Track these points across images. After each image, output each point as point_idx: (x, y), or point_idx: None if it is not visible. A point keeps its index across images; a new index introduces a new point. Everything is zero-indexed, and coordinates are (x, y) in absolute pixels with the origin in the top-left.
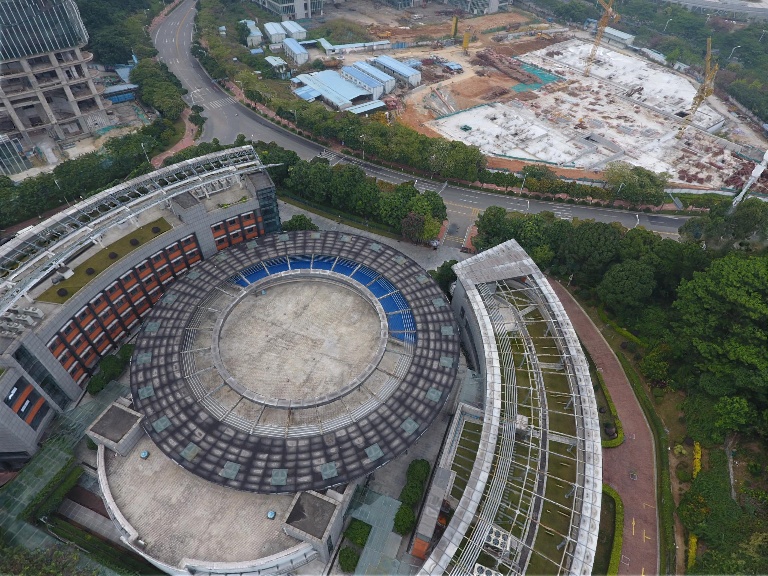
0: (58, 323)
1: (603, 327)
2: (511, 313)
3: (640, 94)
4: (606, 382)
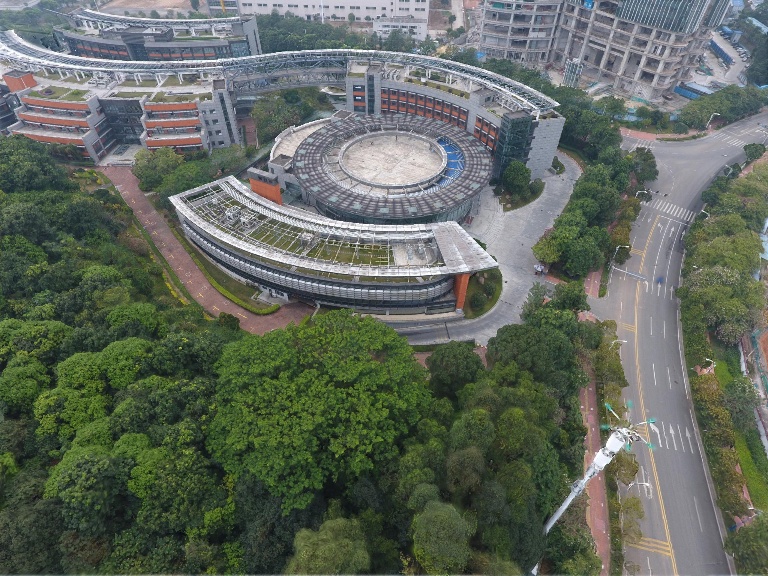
0: (392, 85)
1: None
2: (415, 266)
3: None
4: None
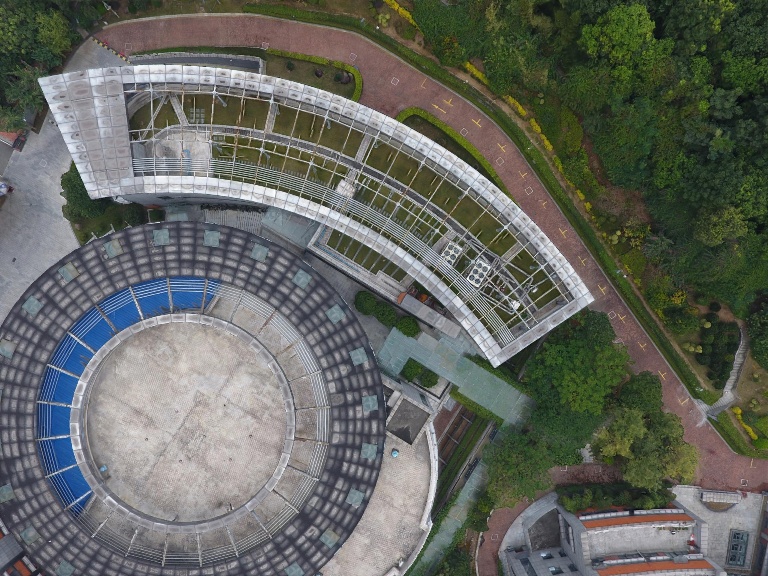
0: None
1: (200, 5)
2: None
3: None
4: (283, 48)
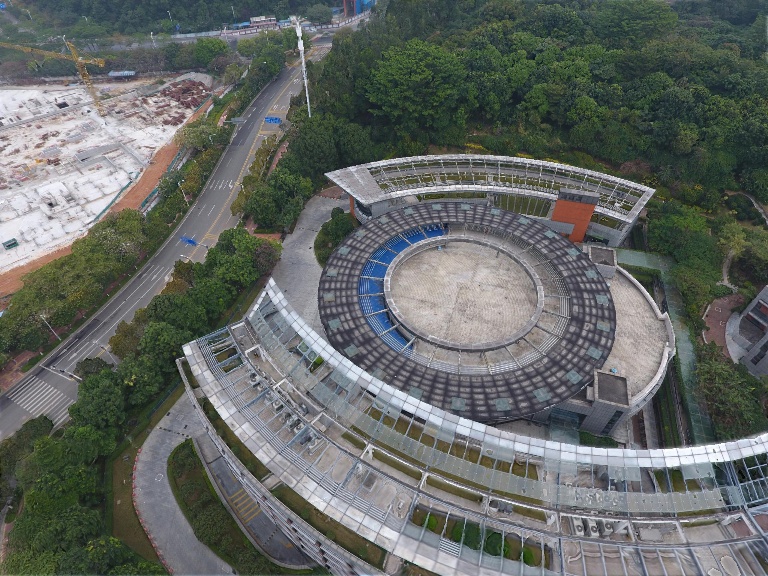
0: None
1: None
2: None
3: (2, 118)
4: None
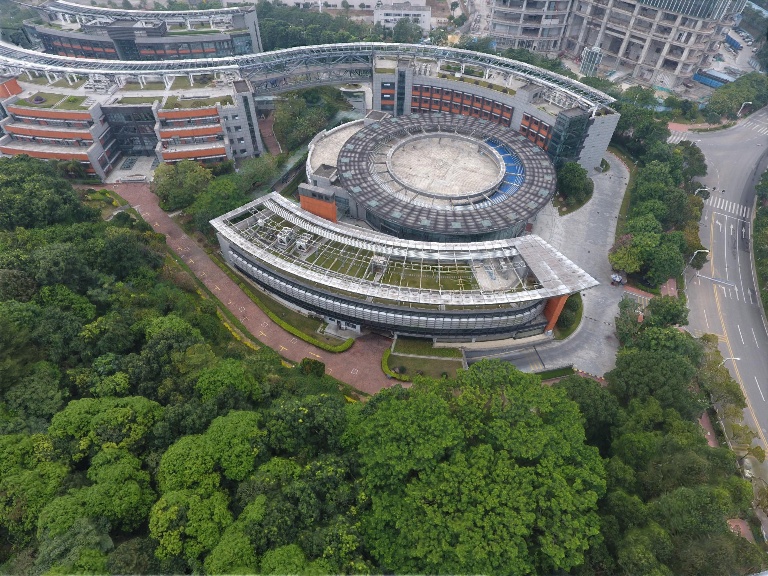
0: (425, 81)
1: None
2: None
3: None
4: None
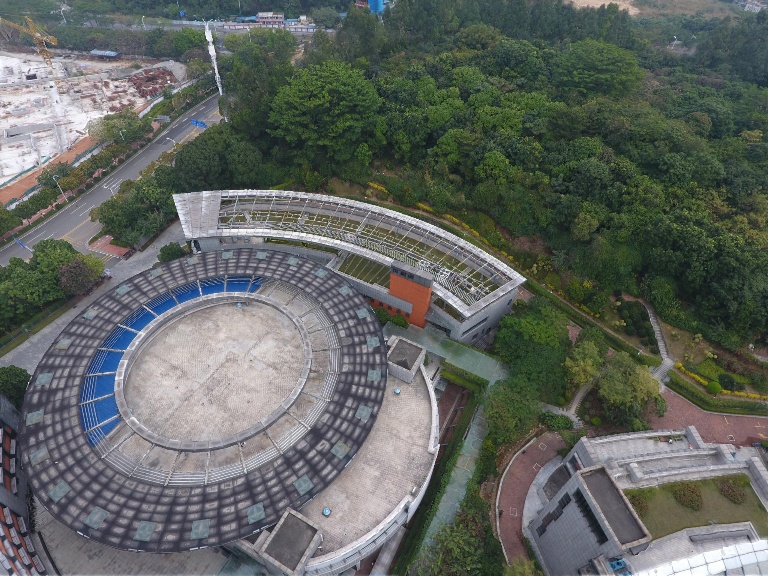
0: None
1: None
2: None
3: None
4: None
